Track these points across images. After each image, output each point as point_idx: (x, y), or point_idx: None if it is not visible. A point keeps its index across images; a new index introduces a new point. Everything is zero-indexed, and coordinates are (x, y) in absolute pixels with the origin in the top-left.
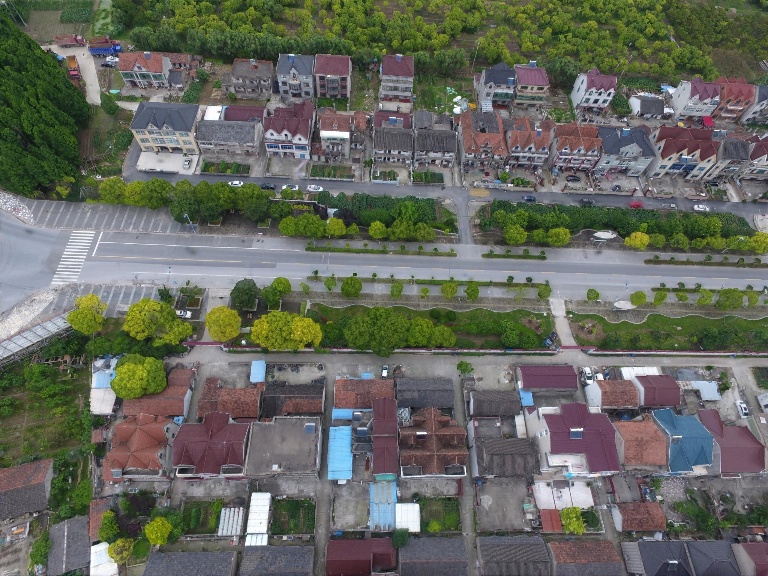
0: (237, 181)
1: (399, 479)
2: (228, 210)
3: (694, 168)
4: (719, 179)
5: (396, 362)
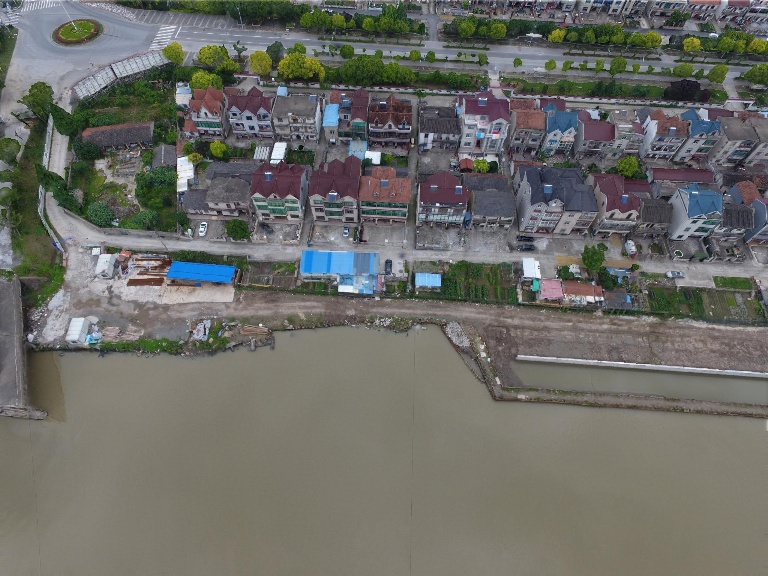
0: None
1: (369, 140)
2: (266, 17)
3: (613, 2)
4: (636, 15)
5: None
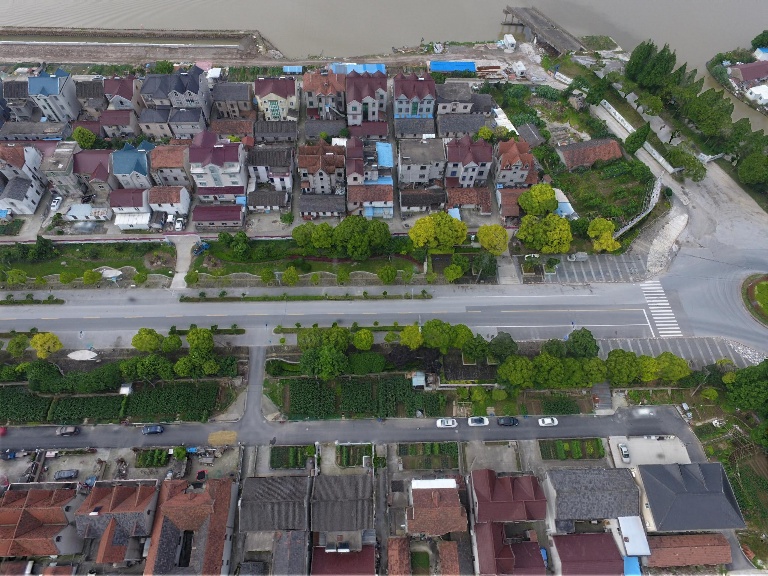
0: (548, 423)
1: None
2: None
3: None
4: None
5: None
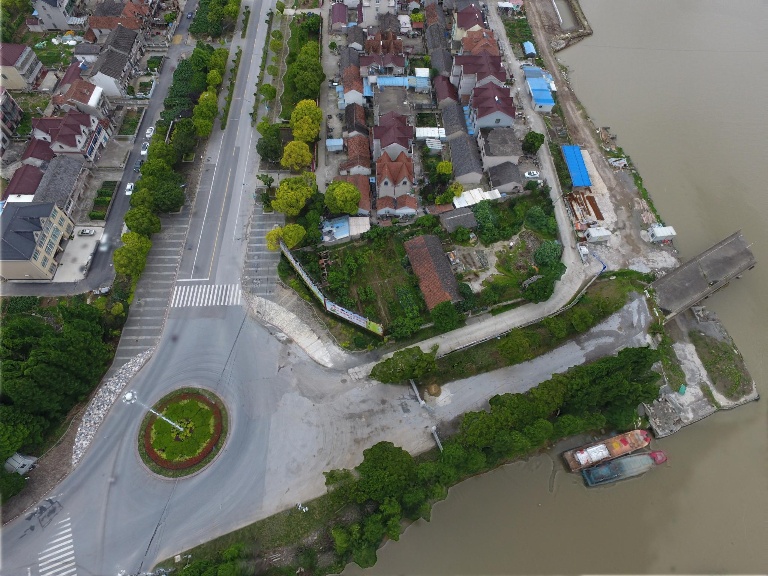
0: (127, 186)
1: None
2: None
3: None
4: None
5: (326, 82)
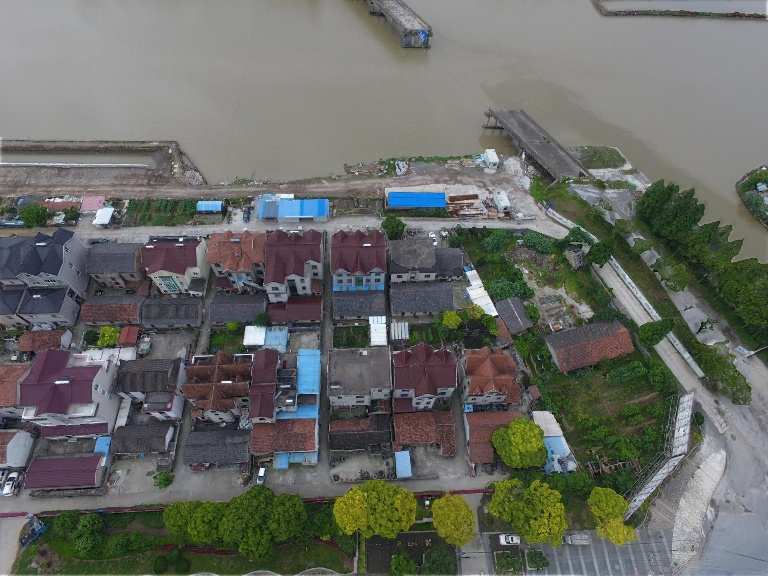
0: None
1: None
2: None
3: None
4: None
5: None
